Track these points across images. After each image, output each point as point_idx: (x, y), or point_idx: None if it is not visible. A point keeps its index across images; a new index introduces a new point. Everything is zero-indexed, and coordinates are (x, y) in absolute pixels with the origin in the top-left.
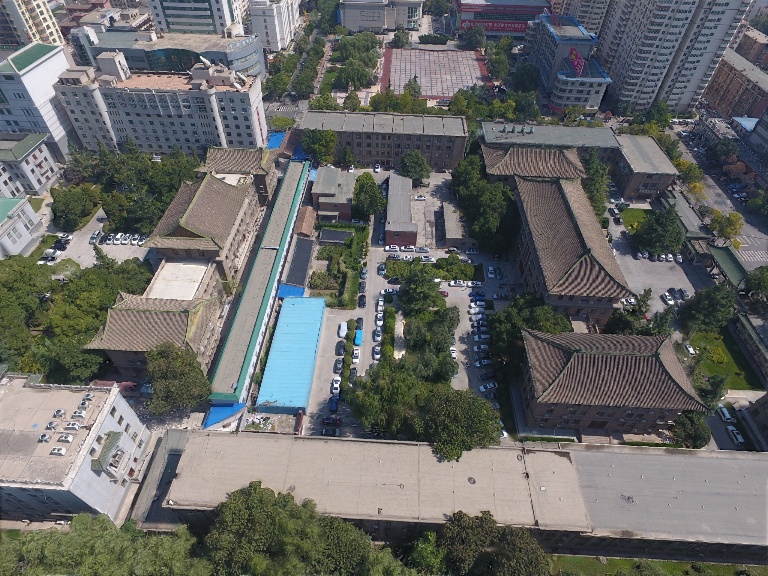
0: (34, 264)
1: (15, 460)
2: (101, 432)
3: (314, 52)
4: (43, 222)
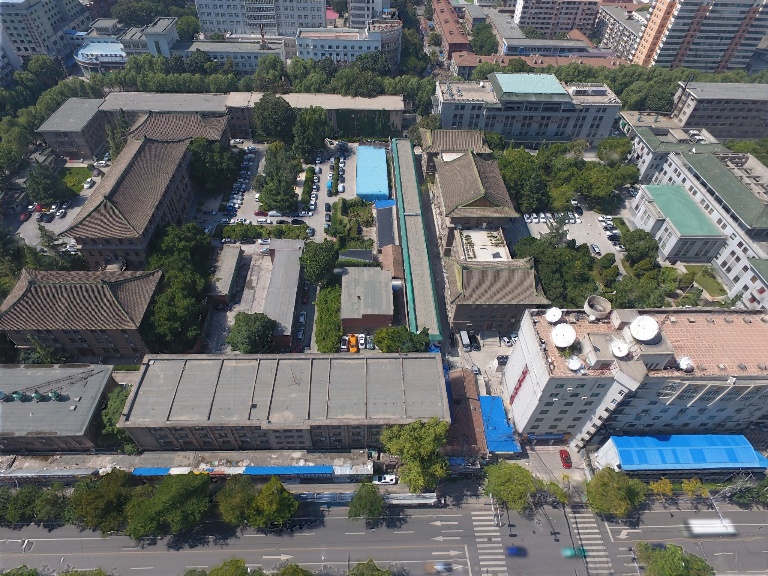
0: (584, 182)
1: (464, 87)
2: None
3: None
4: (667, 263)
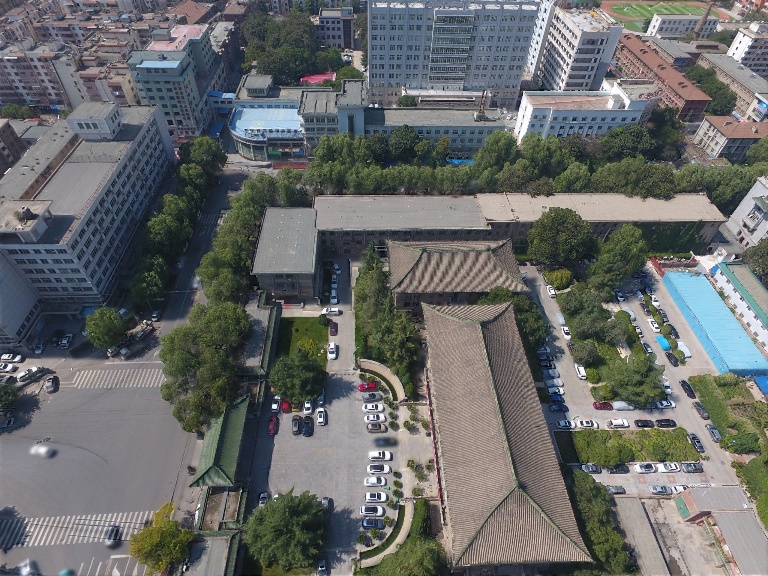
0: None
1: None
2: None
3: None
4: None
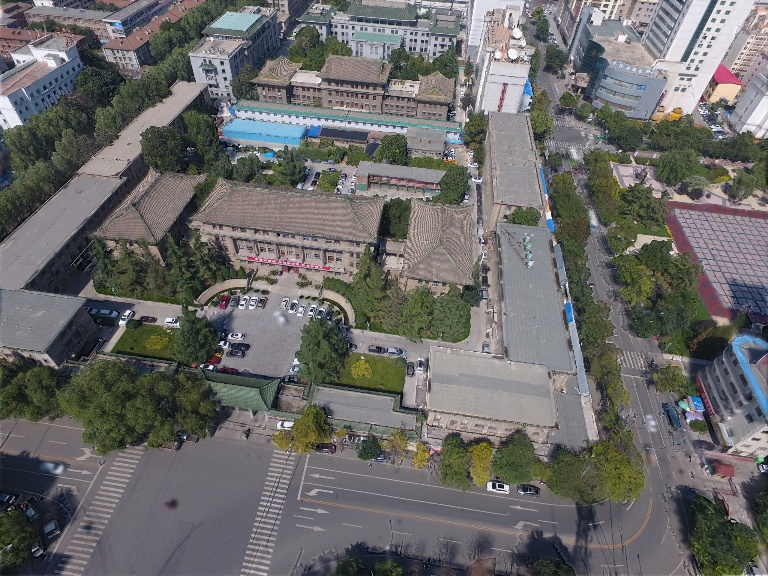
0: None
1: None
2: (213, 61)
3: (730, 143)
4: None
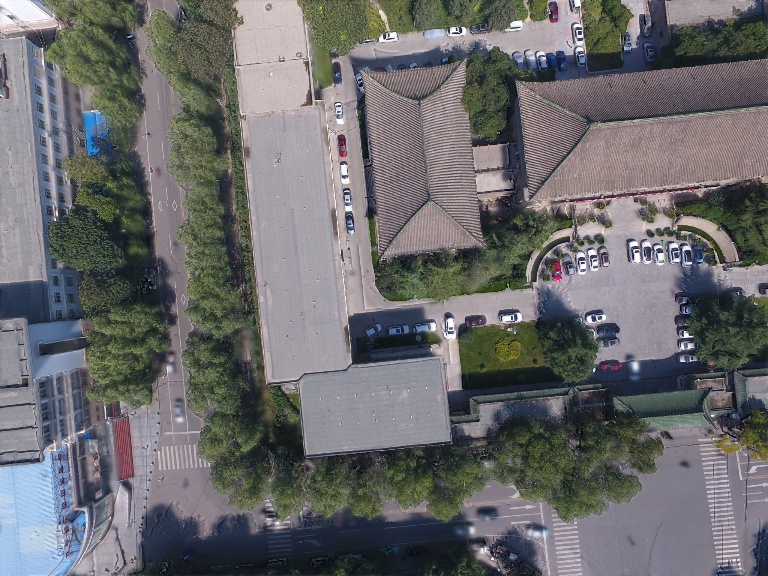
0: None
1: None
2: None
3: None
4: None
